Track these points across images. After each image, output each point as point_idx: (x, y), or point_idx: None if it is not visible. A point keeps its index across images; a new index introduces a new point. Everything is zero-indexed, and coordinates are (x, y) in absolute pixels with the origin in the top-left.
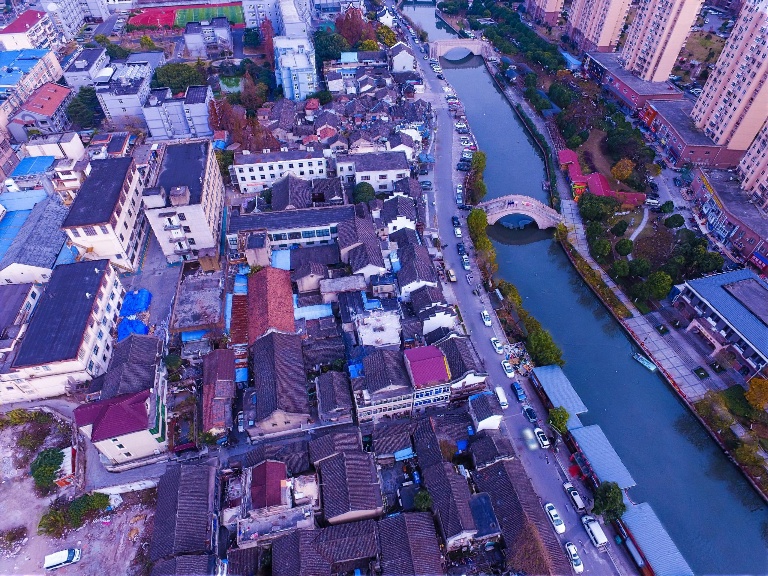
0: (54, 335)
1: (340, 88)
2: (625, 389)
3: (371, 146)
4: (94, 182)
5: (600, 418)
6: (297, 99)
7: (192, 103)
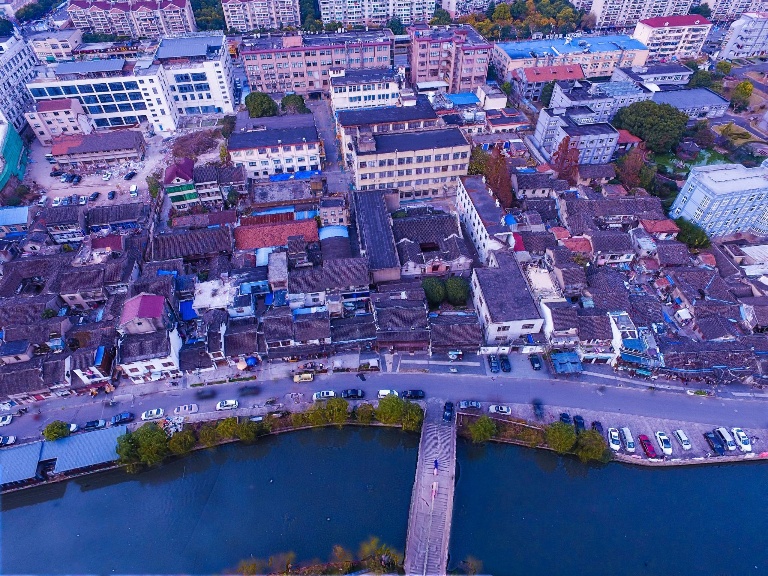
0: (250, 140)
1: (760, 257)
2: (83, 568)
3: (554, 285)
4: (396, 111)
5: (74, 525)
6: (676, 214)
7: (570, 131)
